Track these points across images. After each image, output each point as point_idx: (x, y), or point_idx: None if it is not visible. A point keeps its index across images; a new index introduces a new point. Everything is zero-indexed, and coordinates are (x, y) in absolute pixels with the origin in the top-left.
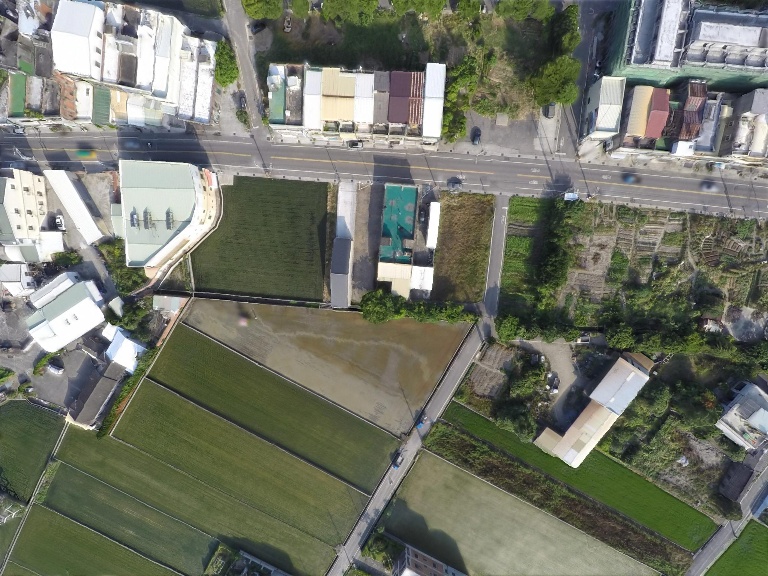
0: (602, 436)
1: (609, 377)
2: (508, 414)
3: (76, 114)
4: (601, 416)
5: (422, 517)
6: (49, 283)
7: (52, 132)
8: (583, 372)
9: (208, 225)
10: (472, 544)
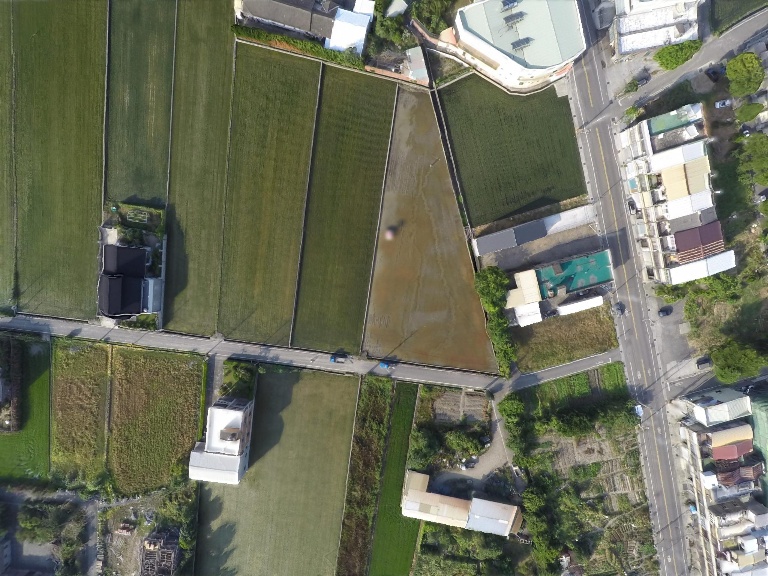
0: None
1: (497, 506)
2: (430, 439)
3: None
4: (459, 514)
5: (289, 402)
6: None
7: None
8: (488, 482)
9: (511, 84)
10: (283, 458)
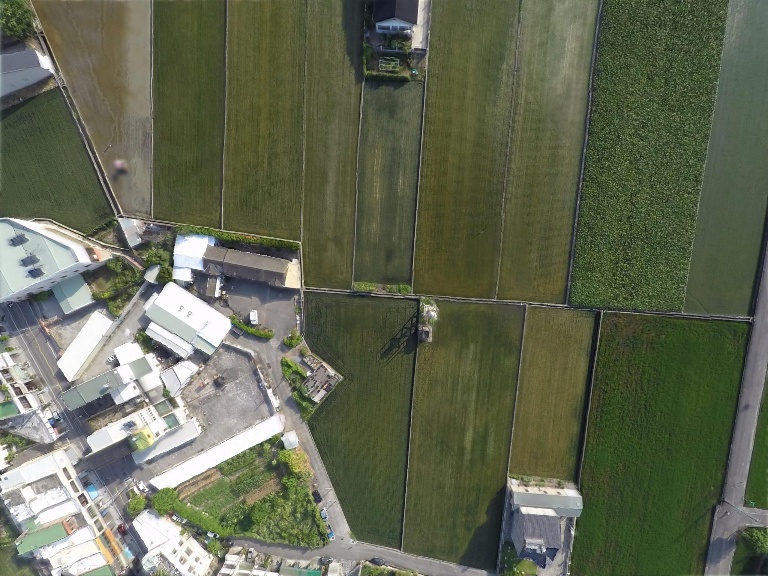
0: None
1: None
2: None
3: (5, 367)
4: None
5: None
6: None
7: None
8: None
9: None
10: None
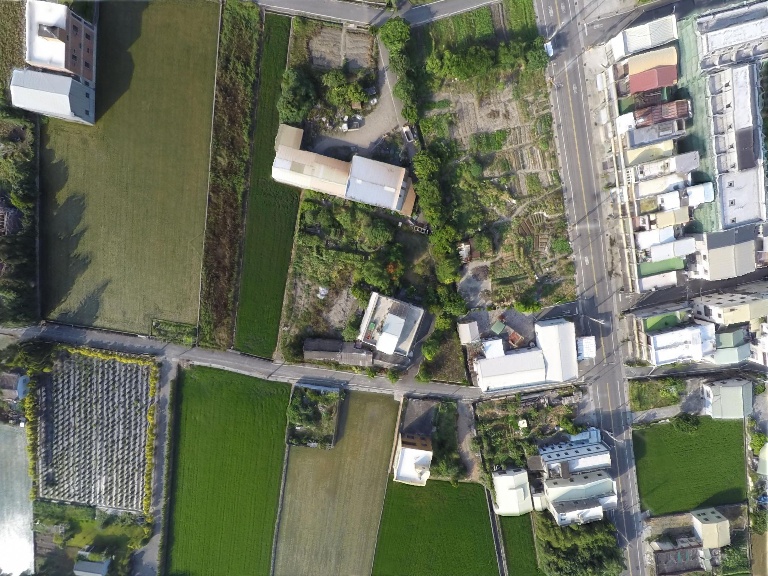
0: (317, 190)
1: (381, 166)
2: (301, 76)
3: None
4: (338, 177)
5: (139, 35)
6: None
7: None
8: (375, 151)
9: None
10: (135, 110)
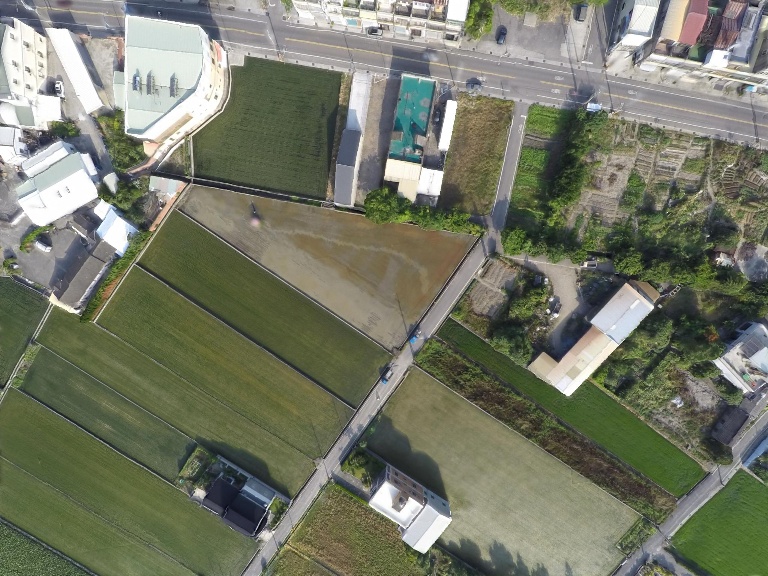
0: (599, 365)
1: (613, 303)
2: (505, 333)
3: None
4: (600, 343)
5: (406, 437)
6: (43, 151)
7: None
8: (586, 299)
9: (213, 106)
10: (454, 469)
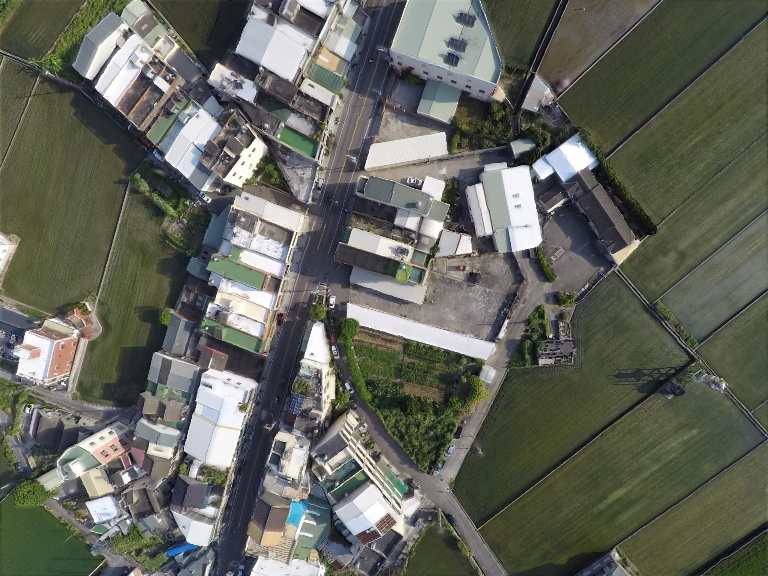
0: None
1: None
2: None
3: None
4: None
5: None
6: (472, 209)
7: (330, 156)
8: None
9: None
10: None
